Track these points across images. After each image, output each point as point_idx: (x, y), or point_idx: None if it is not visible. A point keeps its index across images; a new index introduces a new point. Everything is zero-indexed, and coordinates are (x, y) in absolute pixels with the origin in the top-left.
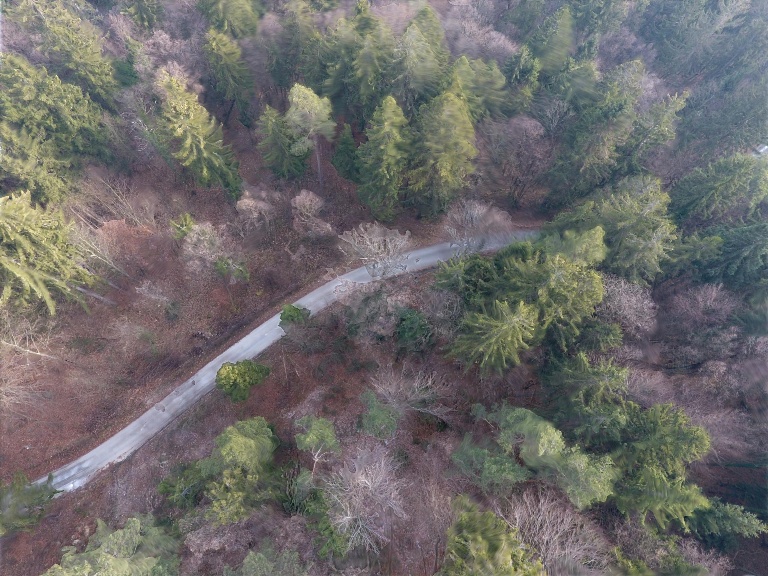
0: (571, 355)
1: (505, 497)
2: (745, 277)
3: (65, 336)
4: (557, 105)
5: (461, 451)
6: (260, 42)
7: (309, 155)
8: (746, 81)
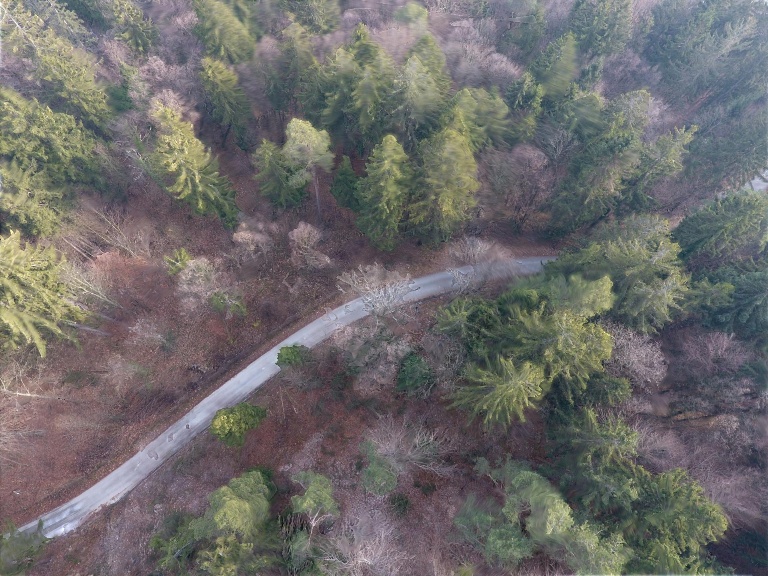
0: (577, 406)
1: (511, 573)
2: (757, 324)
3: (58, 370)
4: (561, 135)
5: (464, 513)
6: (257, 67)
7: (307, 184)
8: (754, 108)
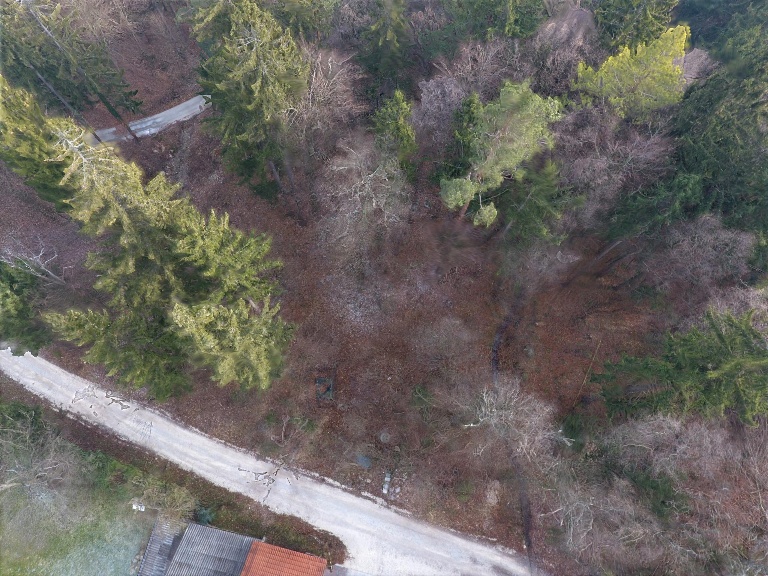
0: None
1: None
2: None
3: (137, 53)
4: None
5: None
6: None
7: None
8: None
